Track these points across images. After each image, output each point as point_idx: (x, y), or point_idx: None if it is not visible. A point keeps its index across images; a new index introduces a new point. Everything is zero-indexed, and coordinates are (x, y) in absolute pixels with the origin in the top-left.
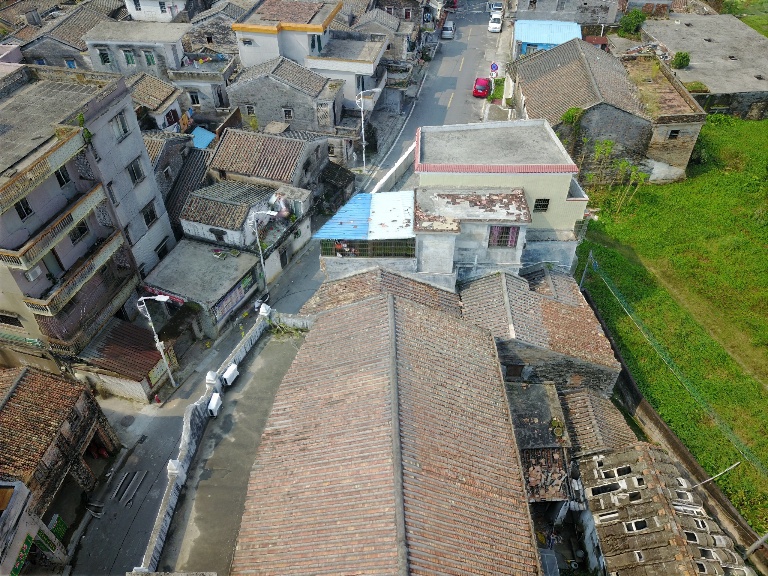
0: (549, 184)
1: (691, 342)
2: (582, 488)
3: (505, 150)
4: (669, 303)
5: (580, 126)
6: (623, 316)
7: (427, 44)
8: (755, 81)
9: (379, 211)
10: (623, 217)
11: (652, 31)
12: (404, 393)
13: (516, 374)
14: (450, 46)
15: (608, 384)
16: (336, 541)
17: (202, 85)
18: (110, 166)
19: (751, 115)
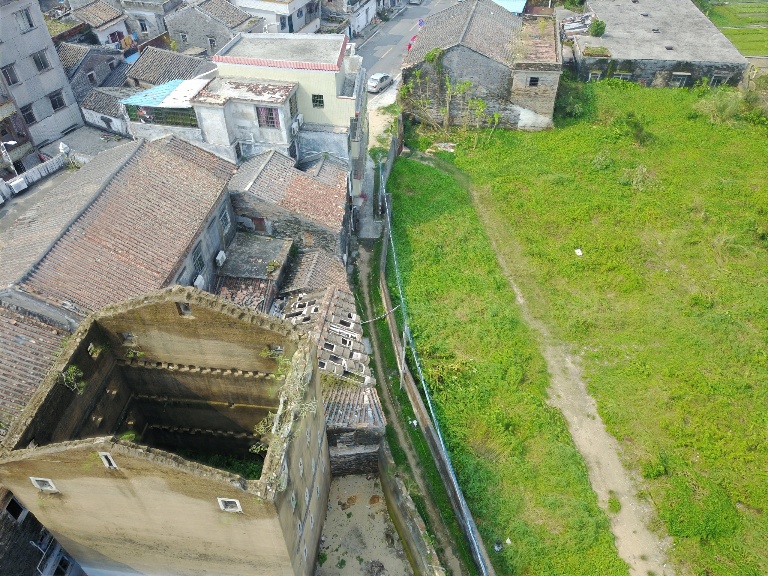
0: (319, 81)
1: (467, 246)
2: (281, 315)
3: (295, 53)
4: (469, 217)
5: (442, 66)
6: (422, 221)
7: (395, 8)
8: (663, 51)
9: (180, 90)
10: (477, 153)
11: (595, 4)
12: (107, 195)
13: (263, 229)
14: (414, 10)
15: (335, 245)
16: (4, 268)
17: (148, 14)
18: (13, 50)
19: (656, 84)
